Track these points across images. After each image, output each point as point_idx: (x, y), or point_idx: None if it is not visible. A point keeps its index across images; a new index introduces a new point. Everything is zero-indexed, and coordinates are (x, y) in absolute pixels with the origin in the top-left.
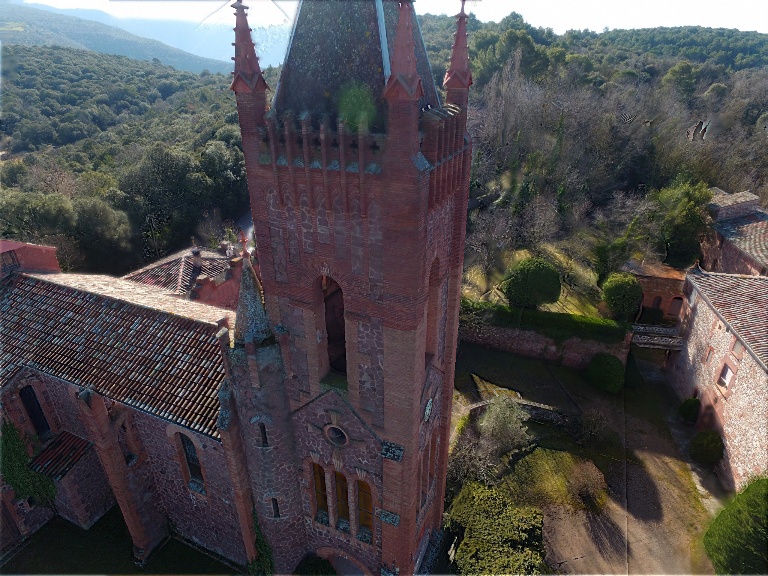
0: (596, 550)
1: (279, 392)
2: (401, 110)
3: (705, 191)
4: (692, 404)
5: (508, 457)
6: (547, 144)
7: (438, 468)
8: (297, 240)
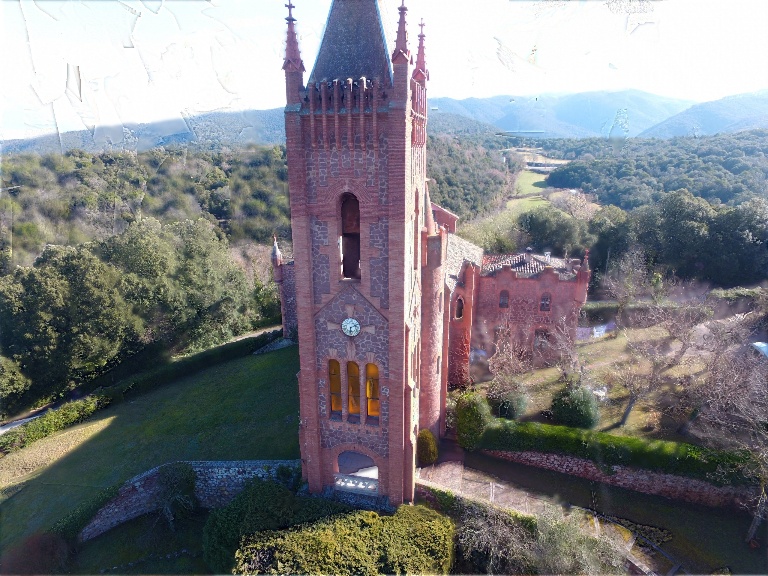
0: None
1: None
2: None
3: None
4: None
5: None
6: None
7: None
8: None
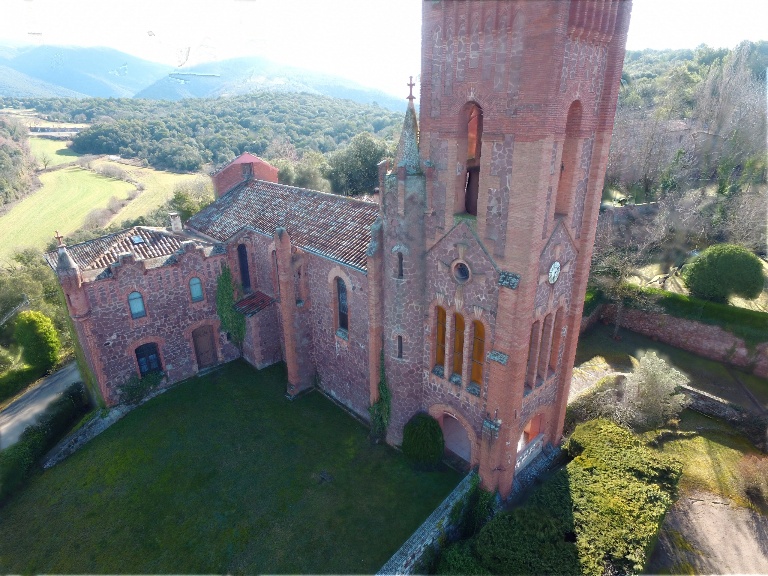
0: (759, 550)
1: (419, 225)
2: None
3: None
4: None
5: (657, 433)
6: None
7: (561, 367)
8: (452, 71)
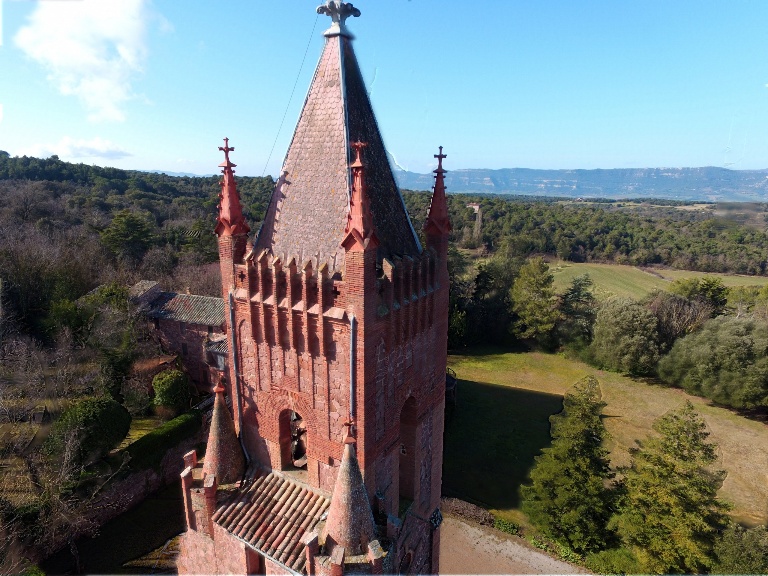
0: None
1: None
2: (445, 240)
3: (121, 288)
4: None
5: None
6: None
7: None
8: (393, 380)
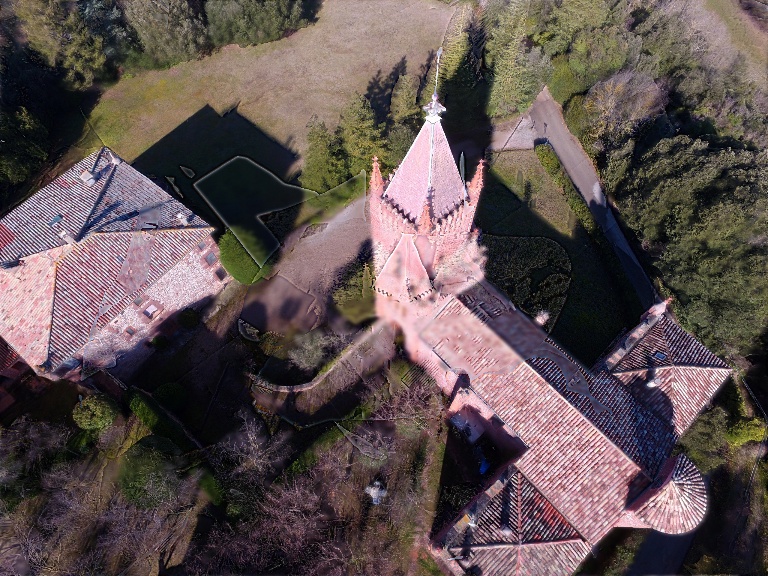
0: None
1: None
2: None
3: None
4: (161, 339)
5: None
6: None
7: None
8: None
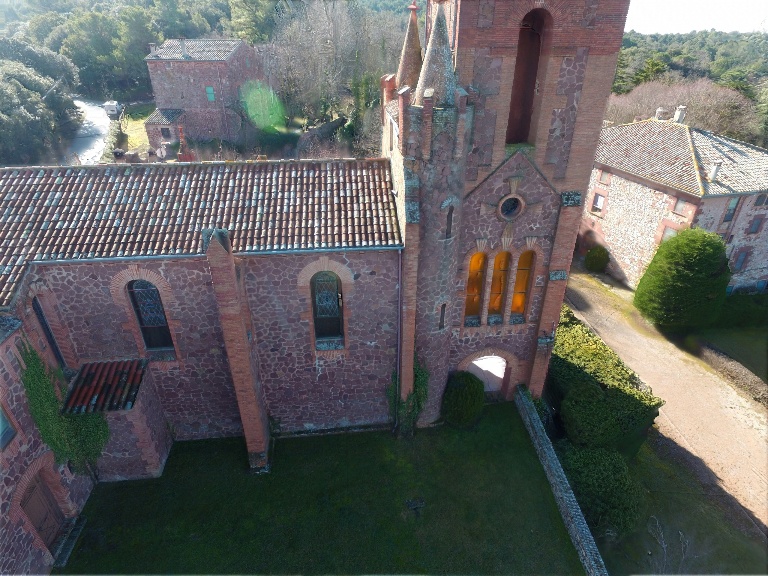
0: None
1: (465, 168)
2: None
3: None
4: None
5: None
6: (383, 63)
7: None
8: None
